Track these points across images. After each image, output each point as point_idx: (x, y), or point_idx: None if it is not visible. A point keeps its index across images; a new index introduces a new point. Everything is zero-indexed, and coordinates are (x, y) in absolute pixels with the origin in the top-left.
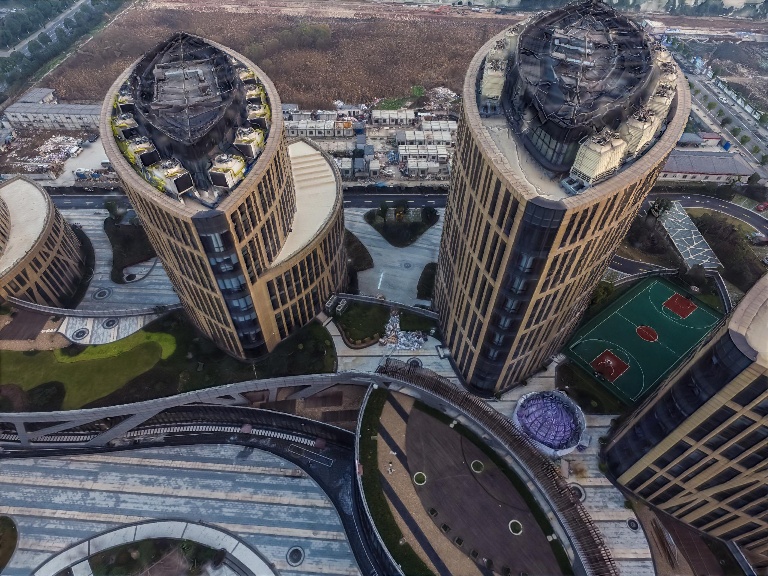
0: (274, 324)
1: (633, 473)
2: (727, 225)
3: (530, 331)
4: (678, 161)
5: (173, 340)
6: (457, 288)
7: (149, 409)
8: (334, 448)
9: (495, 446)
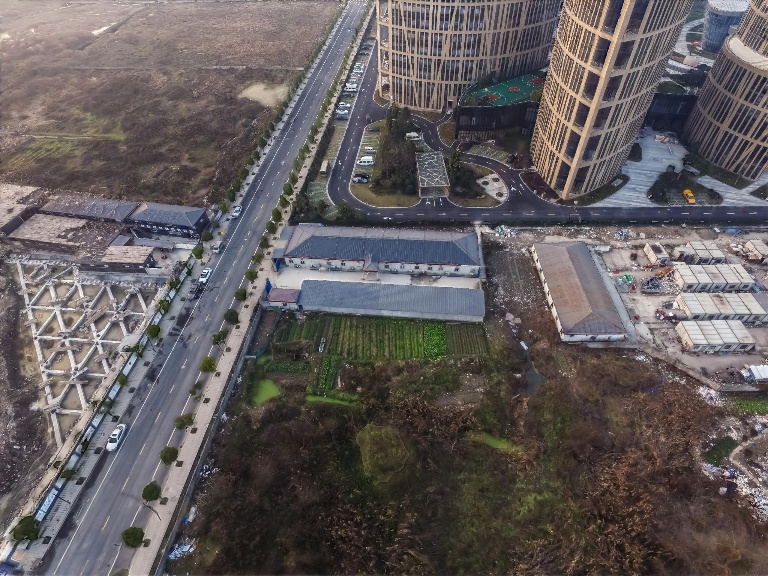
0: None
1: None
2: (397, 164)
3: None
4: (381, 235)
5: None
6: None
7: None
8: None
9: None
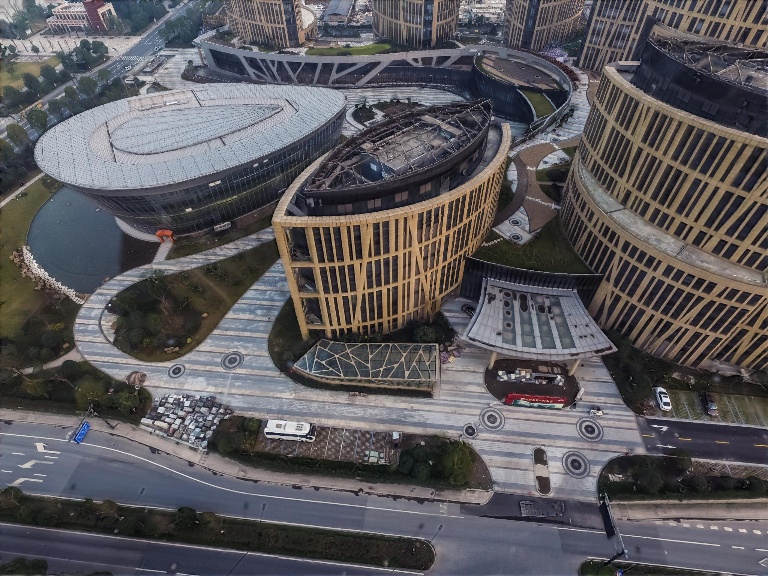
0: (435, 31)
1: (583, 56)
2: None
3: (545, 7)
4: None
5: (388, 45)
6: (515, 4)
7: (387, 59)
8: (459, 87)
9: (530, 62)
